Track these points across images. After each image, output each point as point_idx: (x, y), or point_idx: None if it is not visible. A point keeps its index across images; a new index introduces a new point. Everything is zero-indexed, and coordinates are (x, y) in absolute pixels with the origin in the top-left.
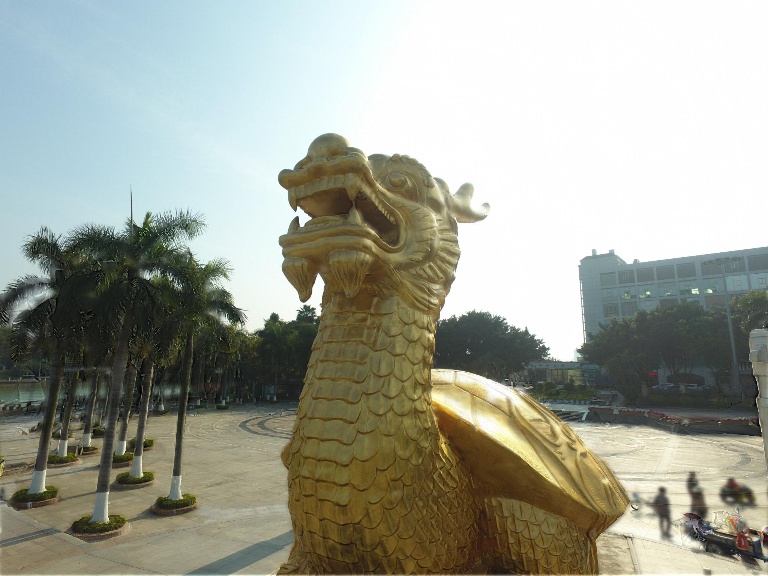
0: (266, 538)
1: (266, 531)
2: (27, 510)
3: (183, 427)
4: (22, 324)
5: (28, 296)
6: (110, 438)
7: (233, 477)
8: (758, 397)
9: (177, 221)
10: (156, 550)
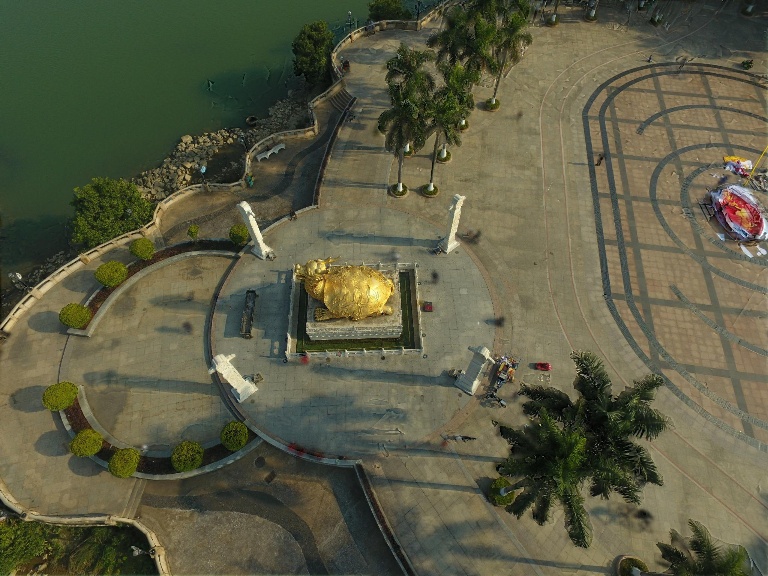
0: (416, 238)
1: (420, 234)
2: None
3: (434, 168)
4: None
5: (396, 78)
6: (400, 169)
7: (479, 177)
8: None
9: None
10: (392, 219)
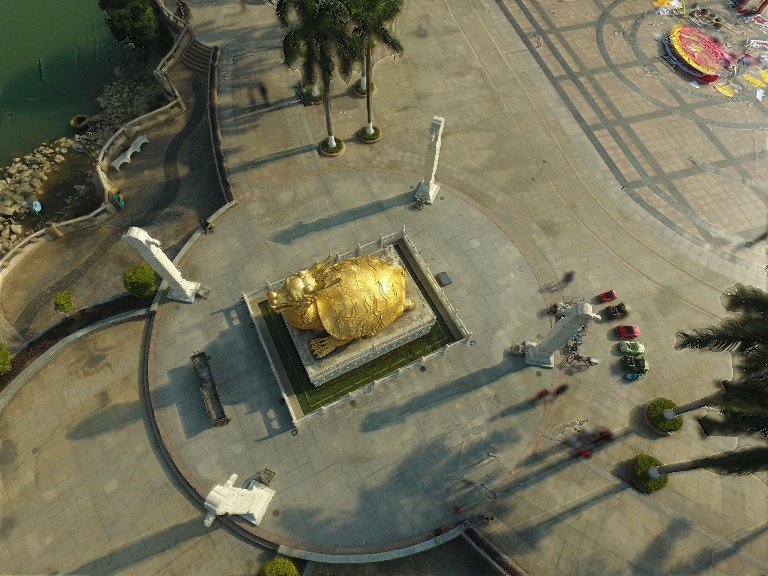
0: (383, 198)
1: (387, 192)
2: (312, 107)
3: (370, 100)
4: (280, 13)
5: None
6: (328, 116)
7: (419, 100)
8: (562, 318)
9: (334, 7)
10: (342, 186)
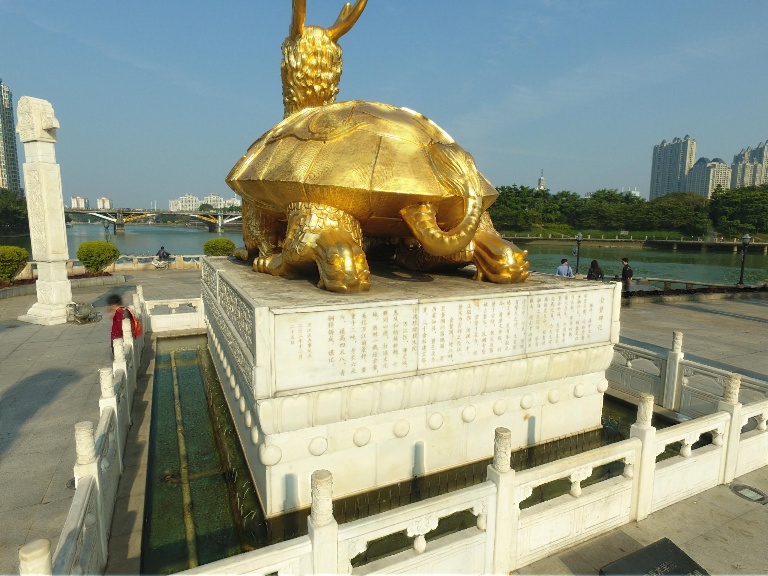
0: None
1: None
2: None
3: None
4: None
5: None
6: None
7: None
8: None
9: None
10: None
